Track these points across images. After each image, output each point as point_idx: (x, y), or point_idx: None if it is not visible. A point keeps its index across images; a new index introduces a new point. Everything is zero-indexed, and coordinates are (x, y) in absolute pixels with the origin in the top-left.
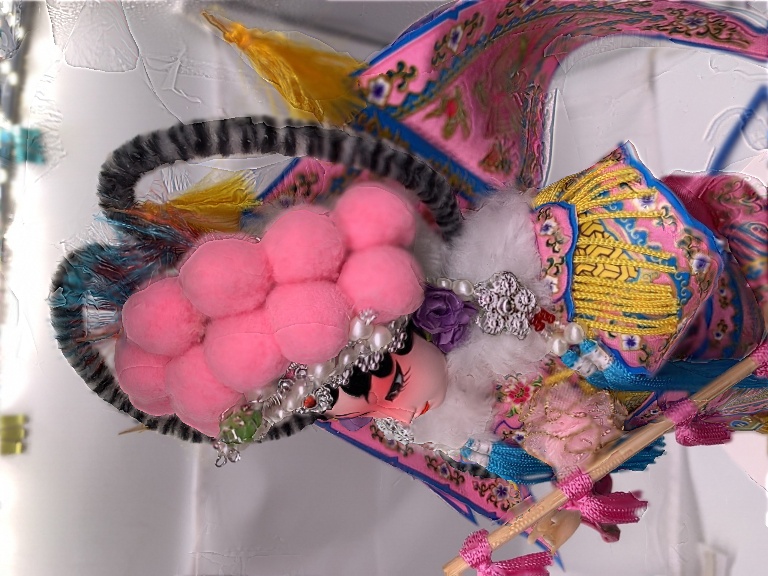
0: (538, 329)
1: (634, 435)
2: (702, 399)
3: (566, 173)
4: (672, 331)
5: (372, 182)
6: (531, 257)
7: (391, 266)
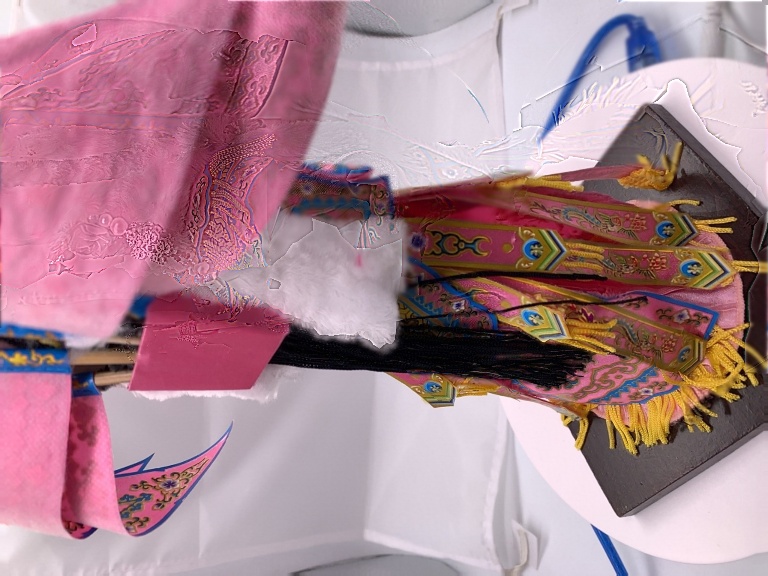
0: (176, 260)
1: (232, 325)
2: (280, 322)
3: (292, 95)
4: (240, 308)
5: (8, 192)
6: (177, 218)
7: (13, 262)
